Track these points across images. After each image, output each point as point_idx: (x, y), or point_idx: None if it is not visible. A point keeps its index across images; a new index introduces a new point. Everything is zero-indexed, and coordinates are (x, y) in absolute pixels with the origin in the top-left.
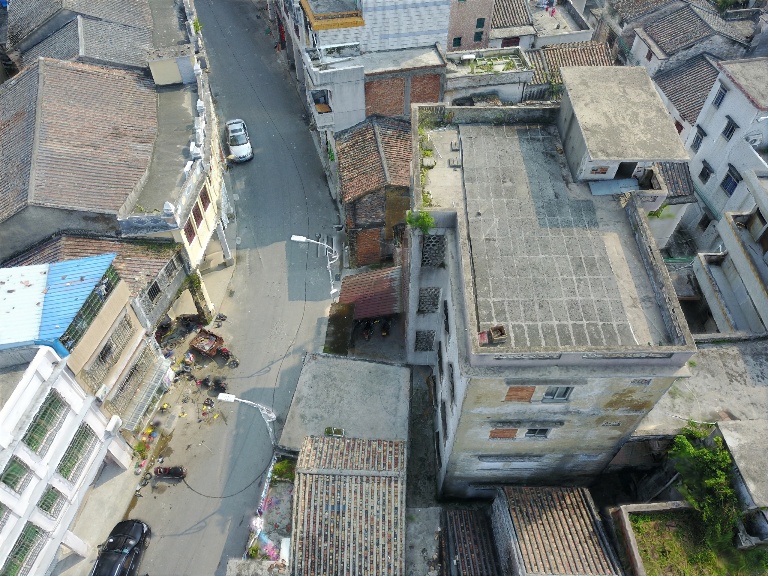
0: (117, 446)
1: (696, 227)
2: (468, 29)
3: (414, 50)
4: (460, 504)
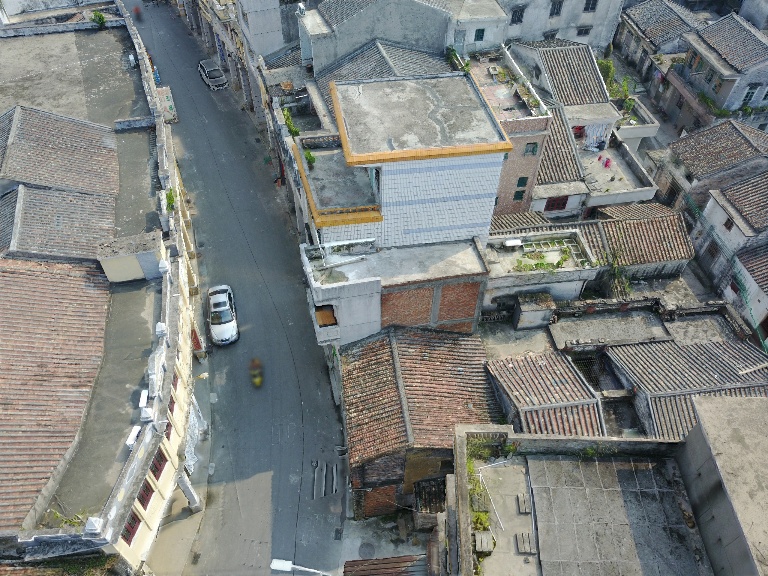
0: None
1: None
2: (507, 188)
3: (446, 246)
4: None
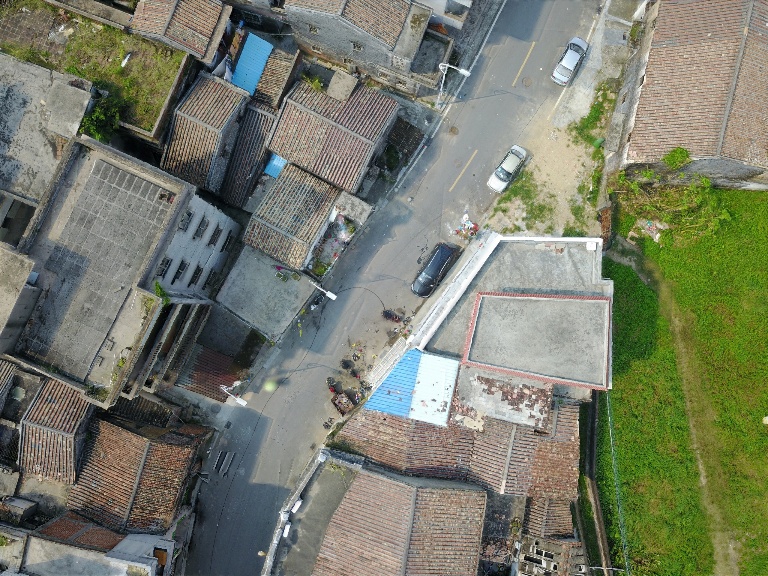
0: None
1: None
2: None
3: (43, 575)
4: None
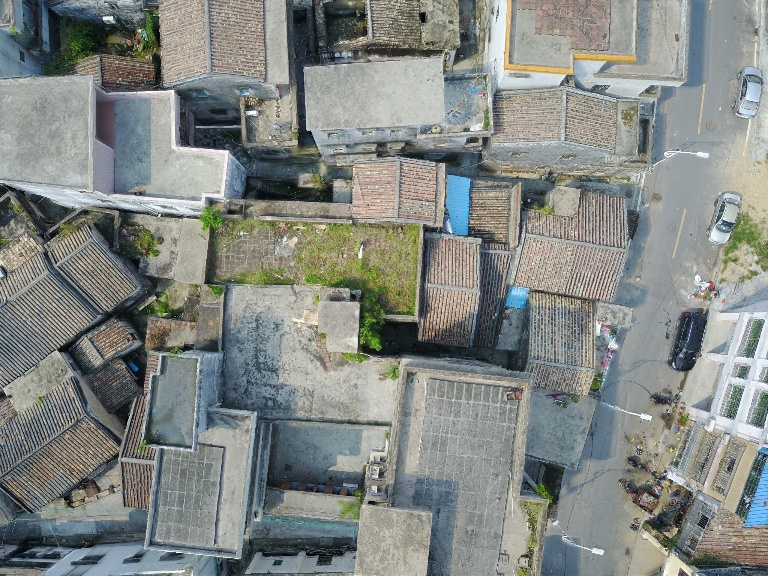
0: (703, 417)
1: (224, 568)
2: None
3: None
4: (473, 357)
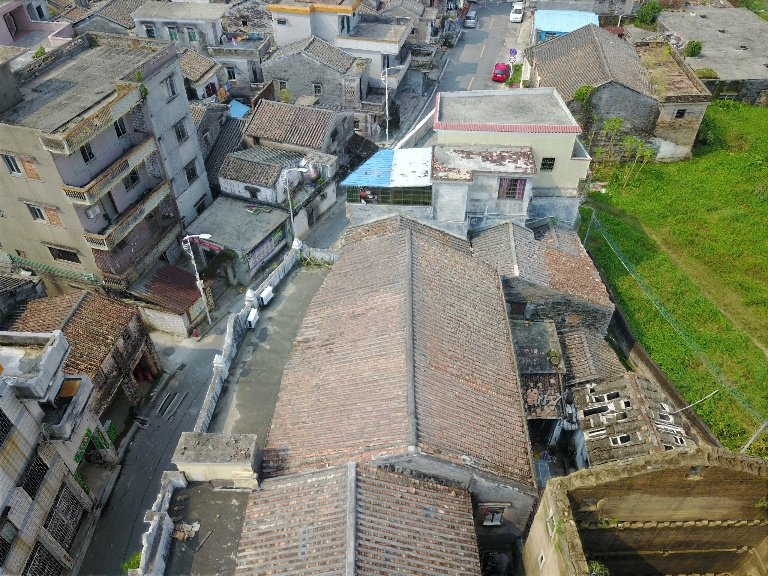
0: None
1: None
2: None
3: None
4: None
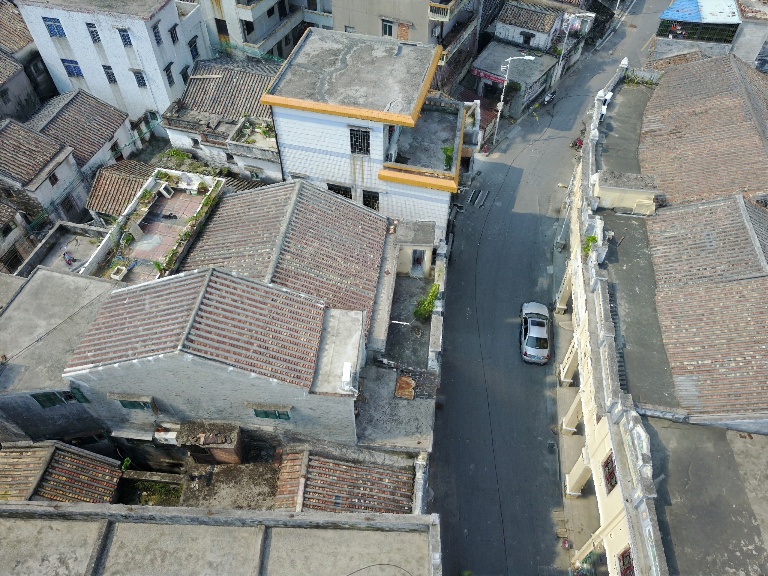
0: None
1: None
2: None
3: None
4: None
